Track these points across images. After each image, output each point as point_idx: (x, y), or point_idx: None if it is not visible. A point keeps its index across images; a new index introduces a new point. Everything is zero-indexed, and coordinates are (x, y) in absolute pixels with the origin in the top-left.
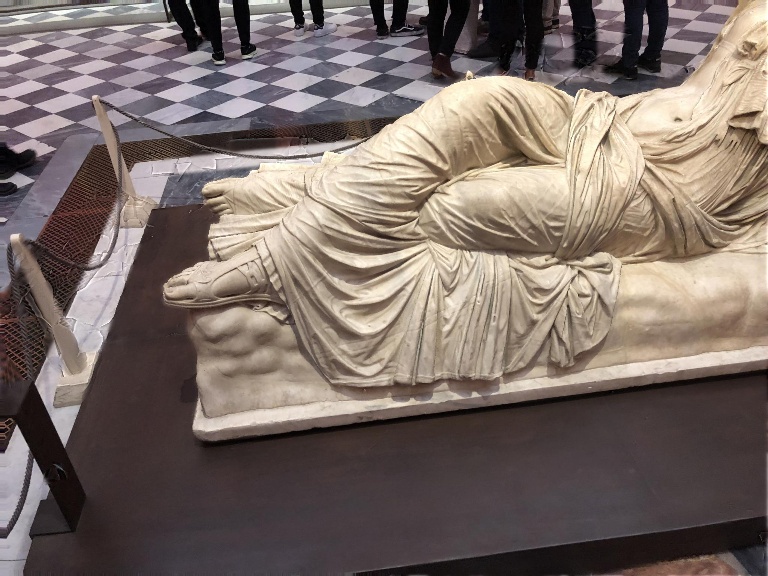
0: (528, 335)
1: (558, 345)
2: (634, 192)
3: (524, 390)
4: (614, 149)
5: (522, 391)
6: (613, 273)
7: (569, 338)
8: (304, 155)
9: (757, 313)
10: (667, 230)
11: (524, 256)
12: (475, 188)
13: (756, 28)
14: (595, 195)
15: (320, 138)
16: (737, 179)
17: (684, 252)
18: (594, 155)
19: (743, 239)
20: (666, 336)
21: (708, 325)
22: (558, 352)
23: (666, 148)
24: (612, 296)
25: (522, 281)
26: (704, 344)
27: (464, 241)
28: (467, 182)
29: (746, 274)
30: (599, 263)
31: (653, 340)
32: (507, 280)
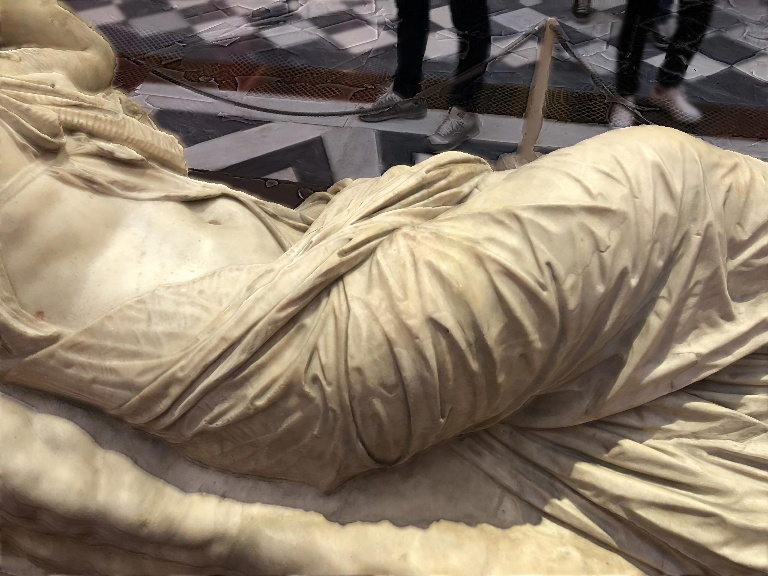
0: None
1: None
2: None
3: None
4: None
5: None
6: None
7: None
8: None
9: None
10: None
11: None
12: None
13: None
14: None
15: None
16: None
17: None
18: None
19: None
20: None
21: None
22: None
23: None
24: None
25: None
26: None
27: None
28: None
29: None
30: None
31: None
32: None
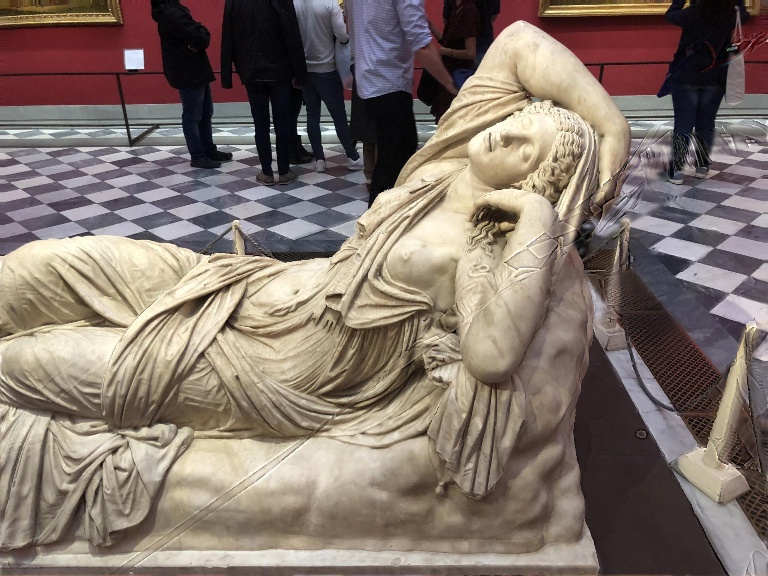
0: (61, 506)
1: (88, 521)
2: (190, 365)
3: (56, 566)
4: None
5: (54, 567)
6: (168, 448)
7: (102, 514)
8: None
9: (321, 511)
10: (241, 408)
11: (73, 420)
12: (15, 346)
13: None
14: (130, 365)
15: None
16: (336, 360)
17: (278, 432)
18: (146, 324)
19: (348, 425)
20: (224, 524)
21: (268, 518)
22: (87, 529)
23: (268, 321)
24: (156, 473)
25: (58, 446)
26: (269, 539)
27: (8, 398)
28: (26, 338)
29: (322, 465)
30: (150, 436)
31: (210, 527)
32: (36, 444)
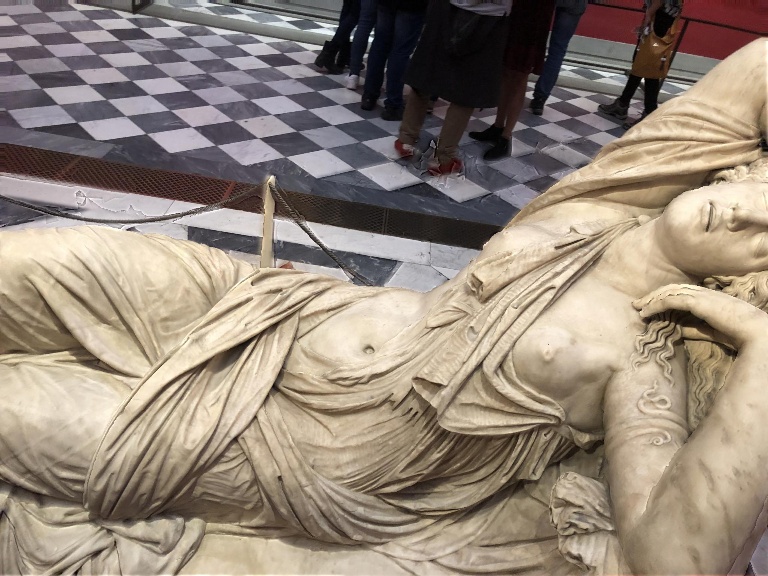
0: None
1: None
2: (216, 455)
3: None
4: (225, 379)
5: None
6: (170, 556)
7: None
8: (77, 216)
9: None
10: (276, 511)
11: (40, 499)
12: None
13: (495, 259)
14: (132, 453)
15: (168, 190)
16: (412, 460)
17: None
18: (161, 390)
19: (411, 540)
20: None
21: None
22: None
23: (326, 389)
24: None
25: (15, 539)
26: None
27: None
28: None
29: None
30: (147, 539)
31: None
32: None
